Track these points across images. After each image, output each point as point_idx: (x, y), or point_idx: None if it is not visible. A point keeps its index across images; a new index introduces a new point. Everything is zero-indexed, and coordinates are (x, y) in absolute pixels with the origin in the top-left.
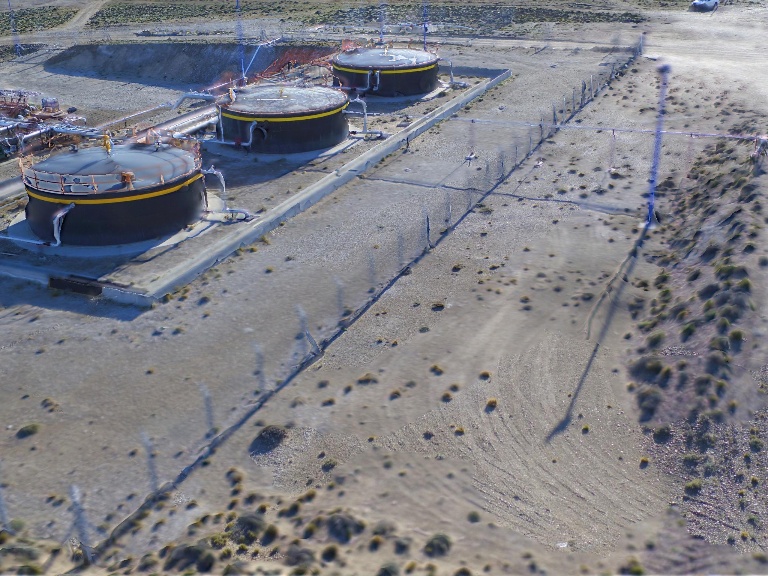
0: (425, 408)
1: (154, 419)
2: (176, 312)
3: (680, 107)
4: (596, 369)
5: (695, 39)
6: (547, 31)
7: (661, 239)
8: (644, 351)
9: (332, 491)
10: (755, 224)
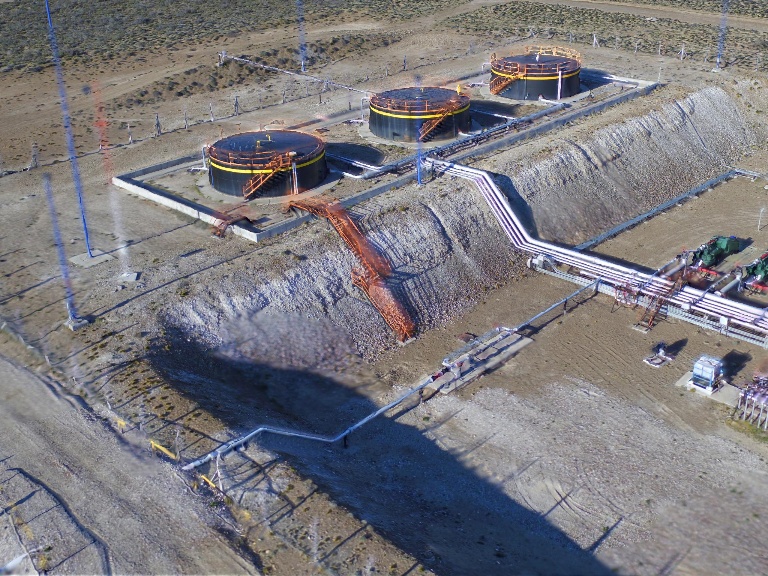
0: None
1: None
2: None
3: None
4: None
5: None
6: None
7: None
8: (379, 46)
9: None
10: None
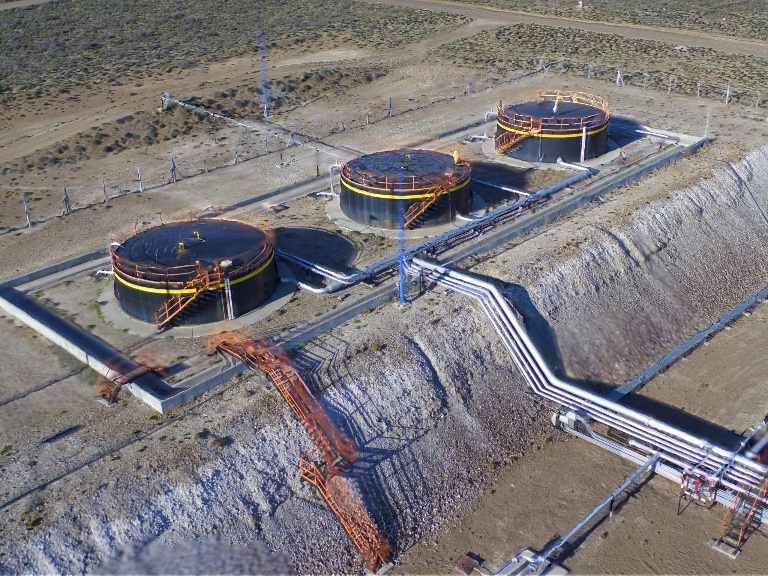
0: None
1: None
2: None
3: None
4: (380, 84)
5: None
6: None
7: (277, 110)
8: (361, 82)
9: (480, 73)
10: (262, 81)
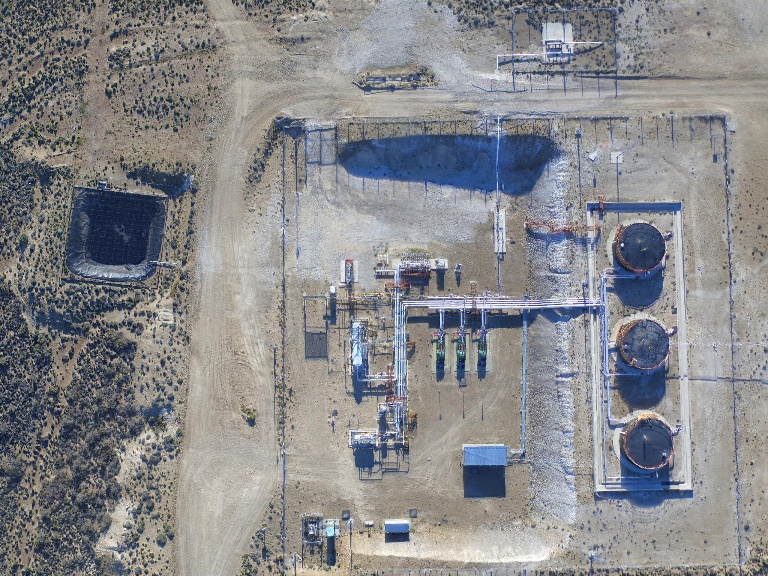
0: (767, 506)
1: (724, 528)
2: (699, 489)
3: (766, 241)
4: None
5: (740, 47)
6: (650, 44)
7: None
8: None
9: (764, 536)
10: None
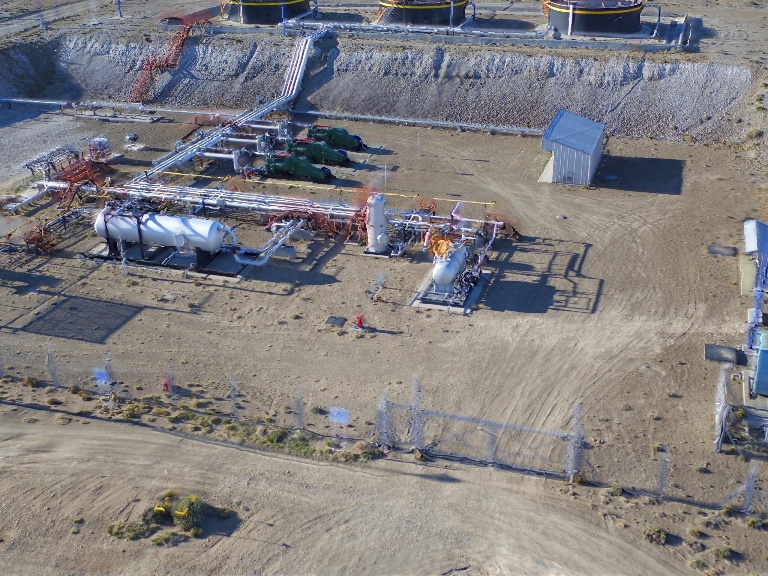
0: None
1: None
2: None
3: None
4: None
5: None
6: (6, 7)
7: None
8: None
9: (767, 0)
10: None
